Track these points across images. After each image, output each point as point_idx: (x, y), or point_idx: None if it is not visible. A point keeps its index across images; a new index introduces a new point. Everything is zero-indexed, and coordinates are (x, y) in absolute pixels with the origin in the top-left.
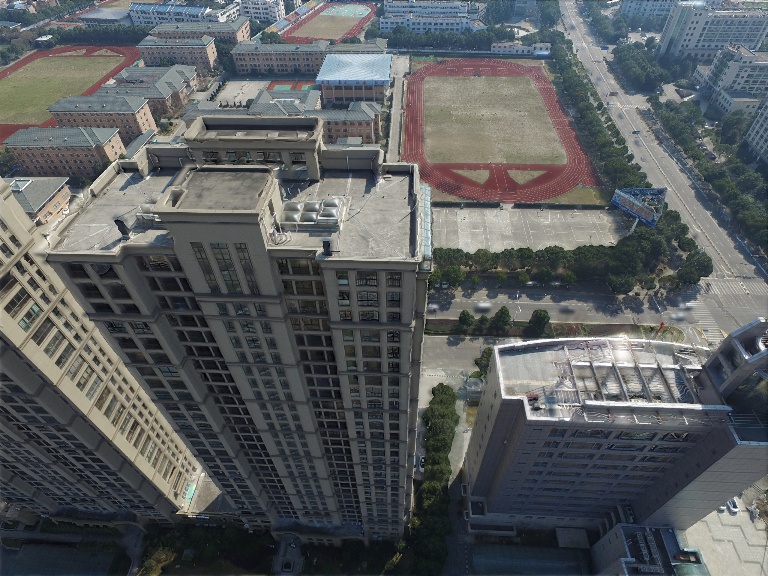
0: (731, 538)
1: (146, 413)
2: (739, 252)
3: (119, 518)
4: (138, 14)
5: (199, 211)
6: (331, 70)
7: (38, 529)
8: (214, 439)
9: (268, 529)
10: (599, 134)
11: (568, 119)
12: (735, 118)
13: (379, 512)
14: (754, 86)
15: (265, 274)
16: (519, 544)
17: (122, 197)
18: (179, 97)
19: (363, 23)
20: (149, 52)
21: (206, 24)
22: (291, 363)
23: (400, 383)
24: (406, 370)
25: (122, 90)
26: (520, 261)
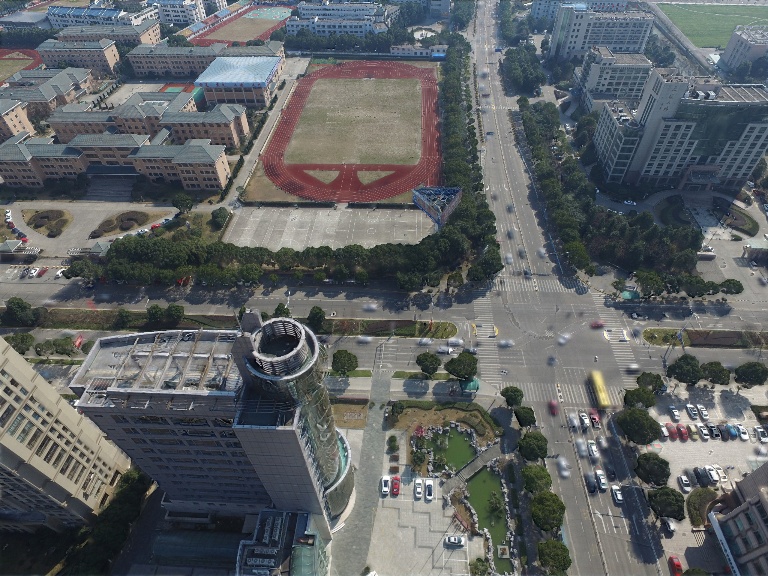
0: (416, 524)
1: None
2: (546, 250)
3: None
4: (56, 17)
5: None
6: (213, 73)
7: None
8: None
9: None
10: (452, 135)
11: (438, 120)
12: (586, 119)
13: (33, 498)
14: (618, 87)
15: None
16: (211, 530)
17: None
18: (65, 99)
19: (280, 26)
20: (49, 55)
21: (111, 27)
22: None
23: None
24: None
25: (7, 93)
26: (316, 259)
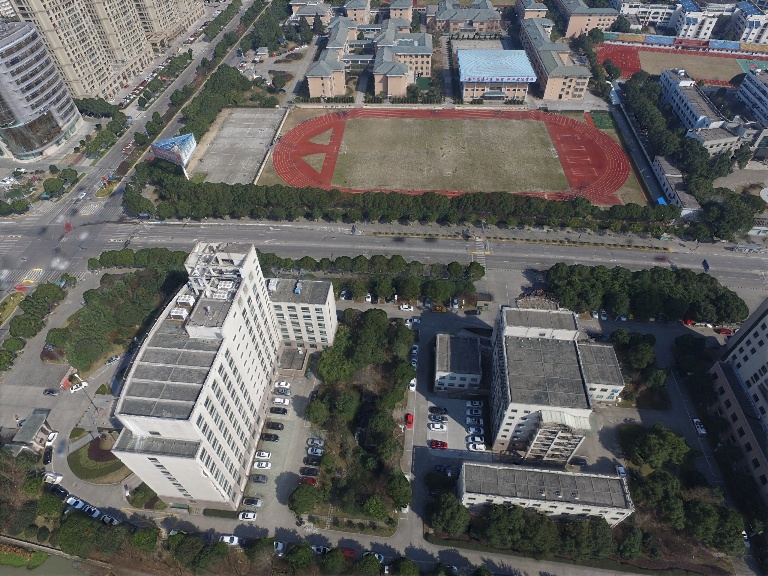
0: None
1: (95, 14)
2: None
3: None
4: None
5: None
6: (480, 53)
7: None
8: None
9: None
10: (358, 193)
11: None
12: (372, 309)
13: None
14: None
15: None
16: None
17: None
18: (450, 25)
19: (721, 83)
20: None
21: None
22: None
23: None
24: None
25: None
26: None
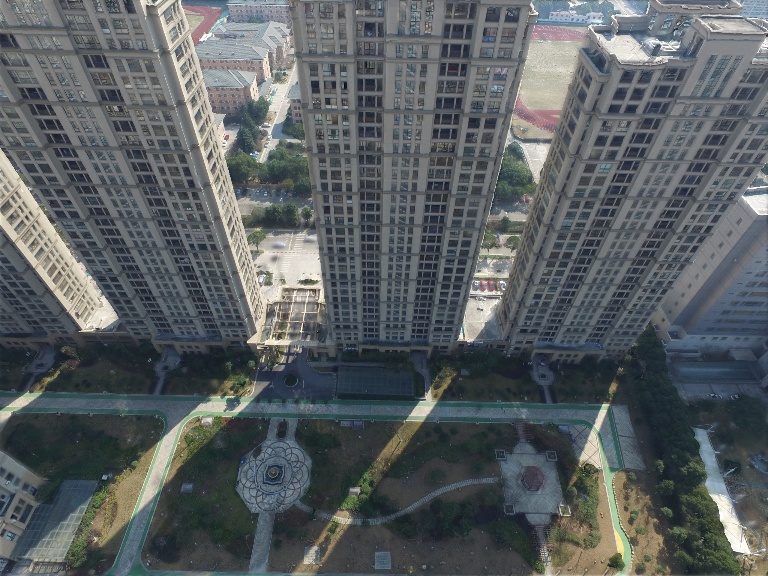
0: None
1: None
2: None
3: (413, 345)
4: None
5: (733, 33)
6: None
7: (339, 360)
8: (574, 240)
9: (524, 352)
10: None
11: None
12: None
13: (630, 322)
14: None
15: (737, 80)
16: (703, 361)
17: (616, 43)
18: (282, 51)
19: None
20: (237, 10)
21: None
22: (691, 158)
23: (752, 173)
24: (766, 160)
25: (230, 43)
26: None
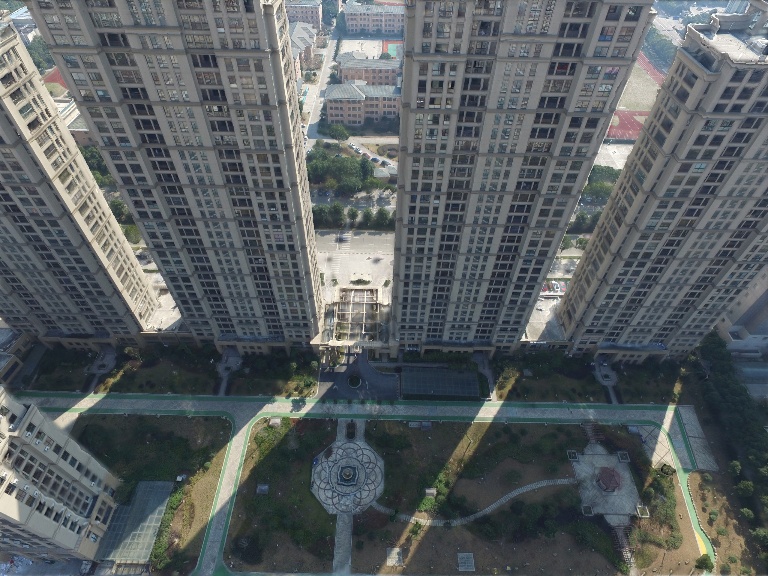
0: None
1: None
2: None
3: (476, 345)
4: None
5: None
6: None
7: (400, 361)
8: (656, 240)
9: (587, 352)
10: None
11: (665, 76)
12: None
13: (698, 323)
14: None
15: None
16: None
17: (720, 42)
18: (310, 51)
19: None
20: None
21: None
22: None
23: None
24: None
25: None
26: None
